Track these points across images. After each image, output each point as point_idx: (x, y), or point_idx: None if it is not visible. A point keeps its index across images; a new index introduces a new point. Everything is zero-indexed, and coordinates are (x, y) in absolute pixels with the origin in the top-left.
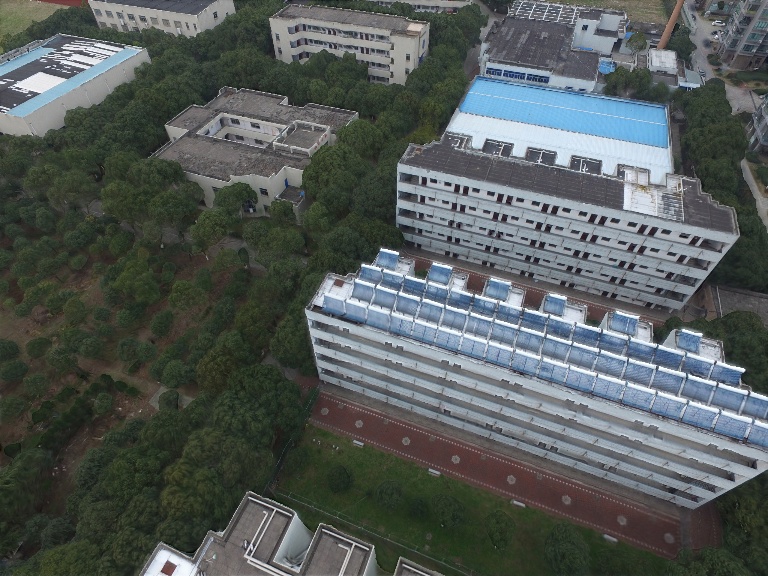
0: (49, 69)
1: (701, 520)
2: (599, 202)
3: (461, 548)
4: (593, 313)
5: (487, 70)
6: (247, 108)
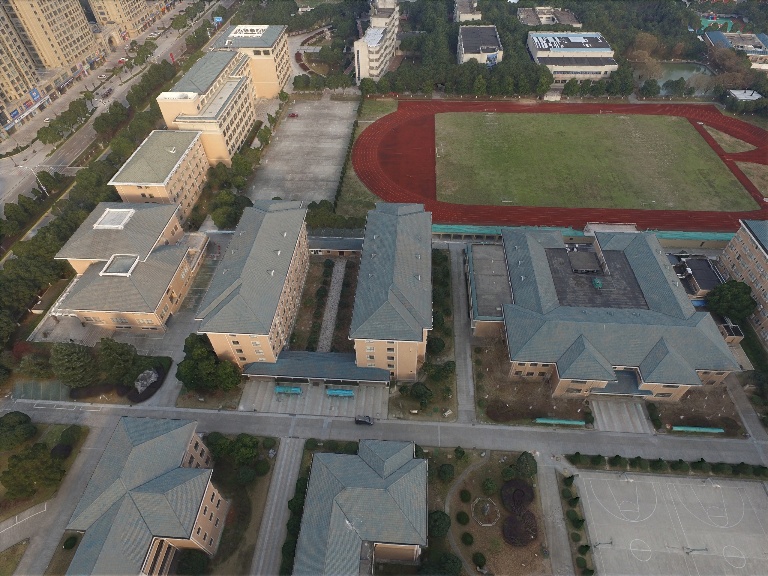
0: (567, 41)
1: None
2: None
3: None
4: None
5: None
6: (535, 21)
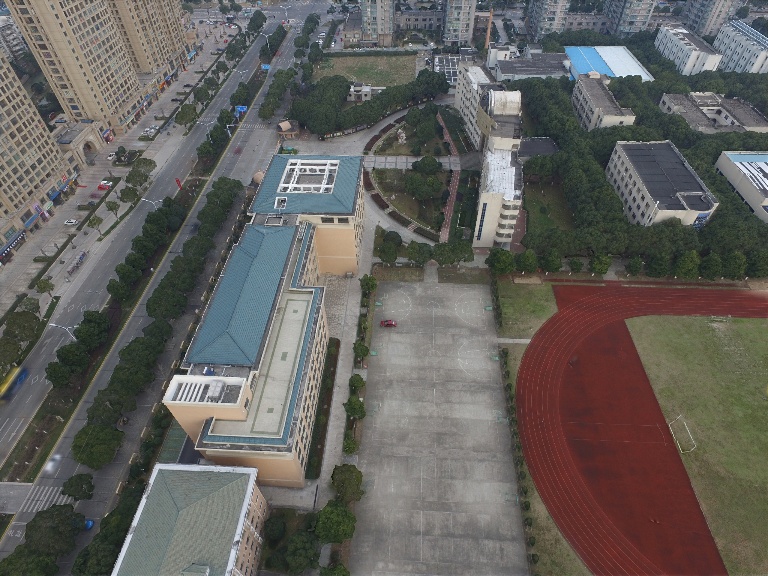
0: None
1: None
2: None
3: None
4: None
5: None
6: None
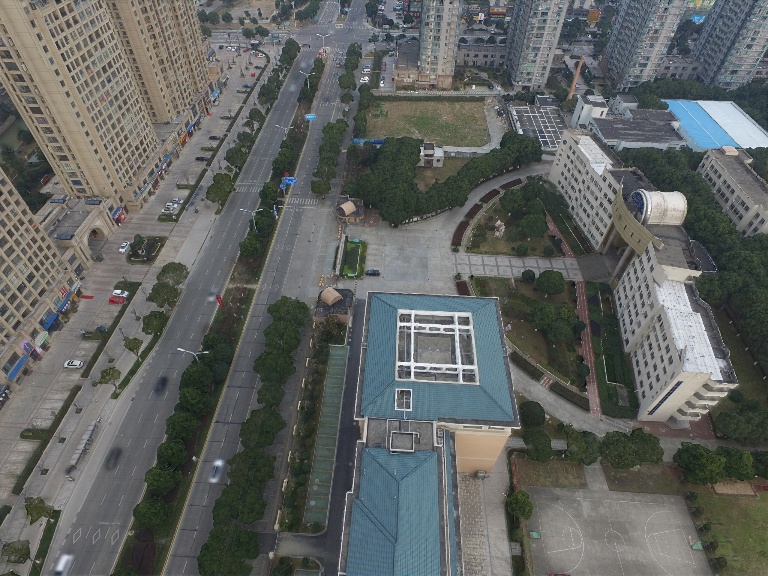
0: None
1: None
2: None
3: None
4: None
5: (684, 146)
6: None
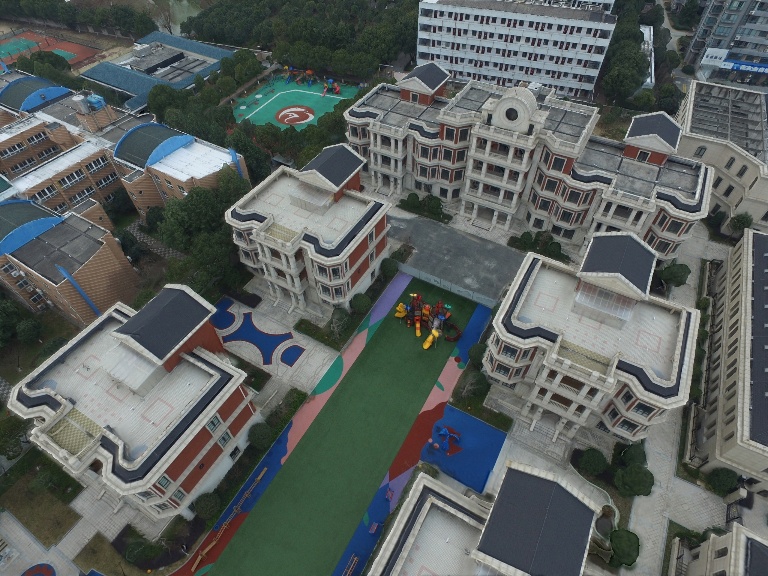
0: None
1: None
2: None
3: None
4: None
5: None
6: None
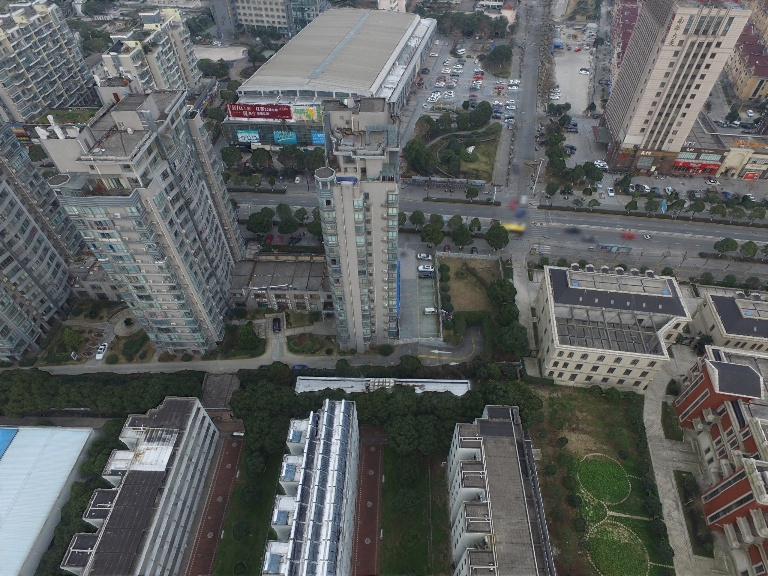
0: None
1: (362, 434)
2: (155, 491)
3: (418, 567)
4: (219, 494)
5: None
6: None
